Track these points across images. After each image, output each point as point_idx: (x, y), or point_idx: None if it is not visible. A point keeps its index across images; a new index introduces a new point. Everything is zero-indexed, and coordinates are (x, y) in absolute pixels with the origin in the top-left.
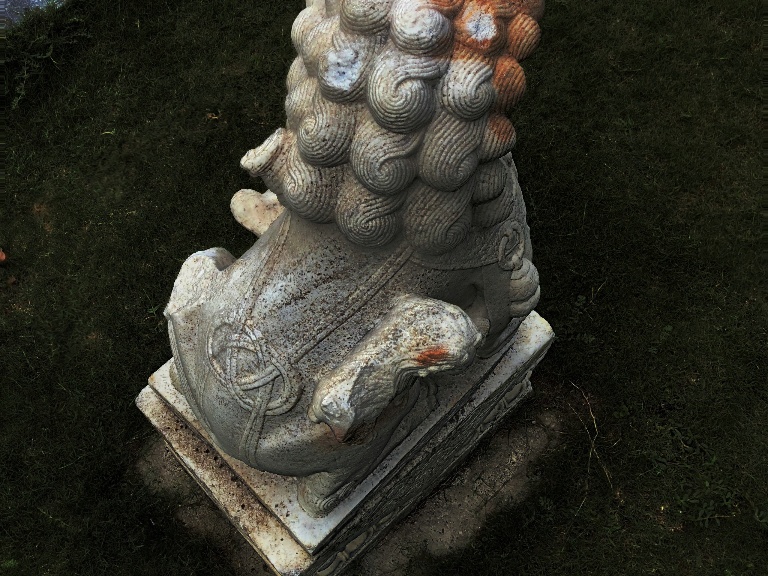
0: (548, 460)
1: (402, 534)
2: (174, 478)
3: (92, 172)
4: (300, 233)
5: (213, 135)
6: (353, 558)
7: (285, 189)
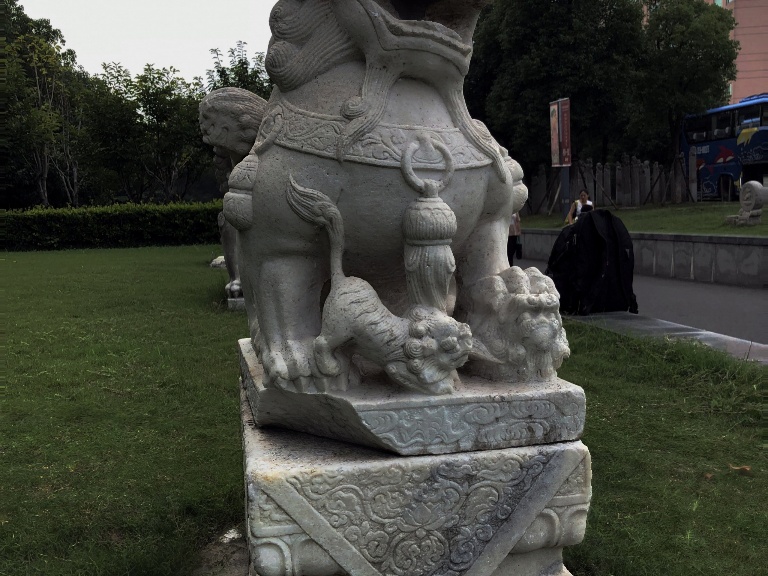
0: None
1: None
2: None
3: None
4: None
5: None
6: None
7: None
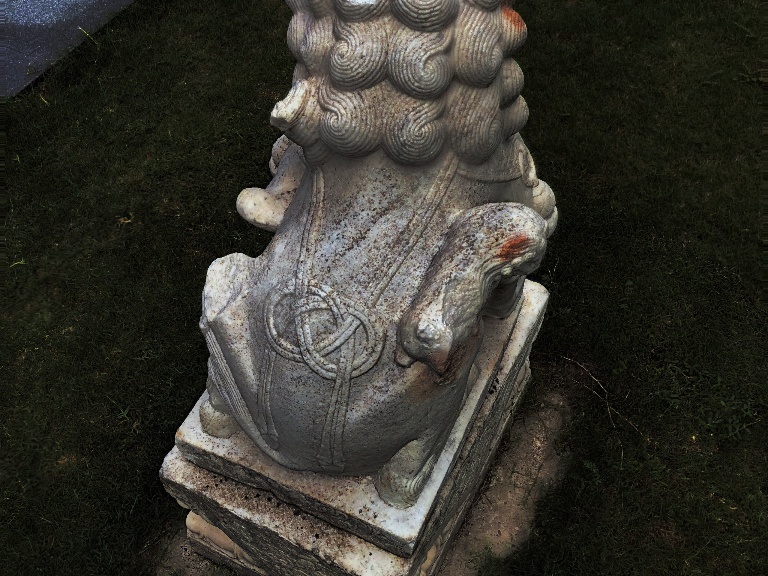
0: (571, 432)
1: (461, 549)
2: (202, 574)
3: (12, 303)
4: (341, 180)
5: (131, 238)
6: None
7: (326, 126)
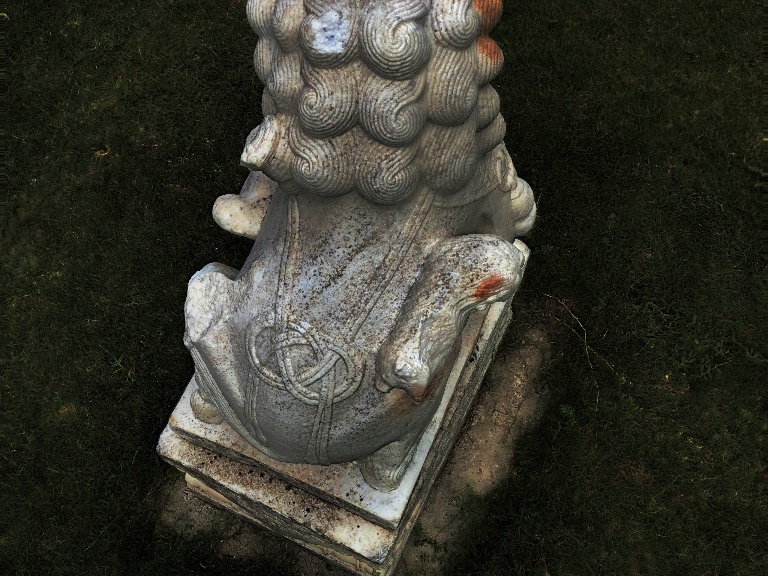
0: (550, 371)
1: (444, 487)
2: (204, 517)
3: None
4: (315, 214)
5: (109, 172)
6: (413, 525)
7: (298, 172)
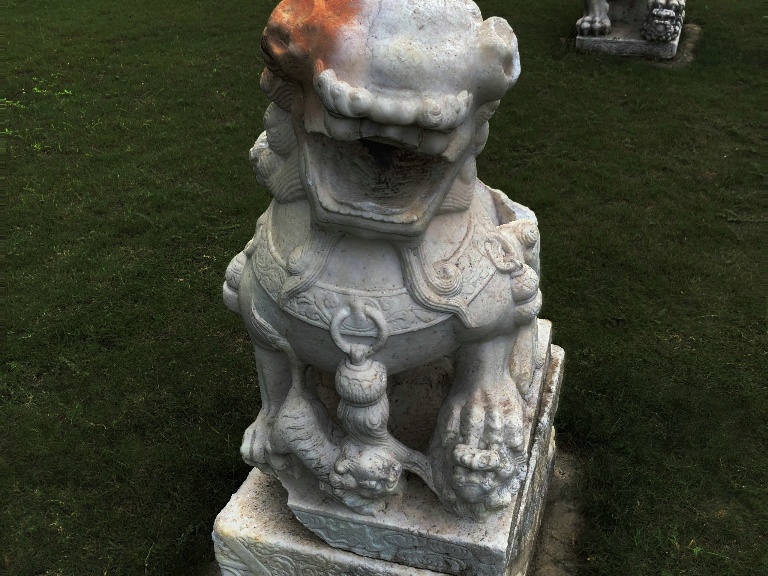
0: None
1: None
2: None
3: None
4: None
5: None
6: None
7: None
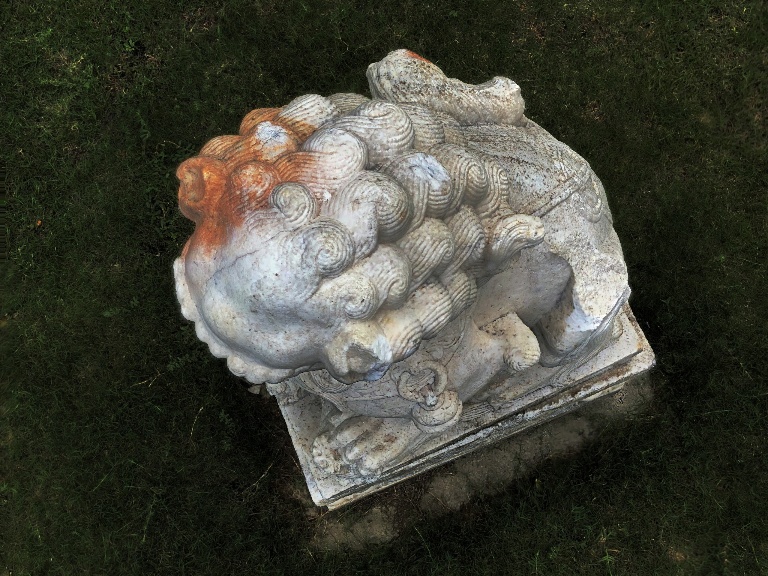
0: None
1: None
2: None
3: None
4: None
5: None
6: None
7: None
